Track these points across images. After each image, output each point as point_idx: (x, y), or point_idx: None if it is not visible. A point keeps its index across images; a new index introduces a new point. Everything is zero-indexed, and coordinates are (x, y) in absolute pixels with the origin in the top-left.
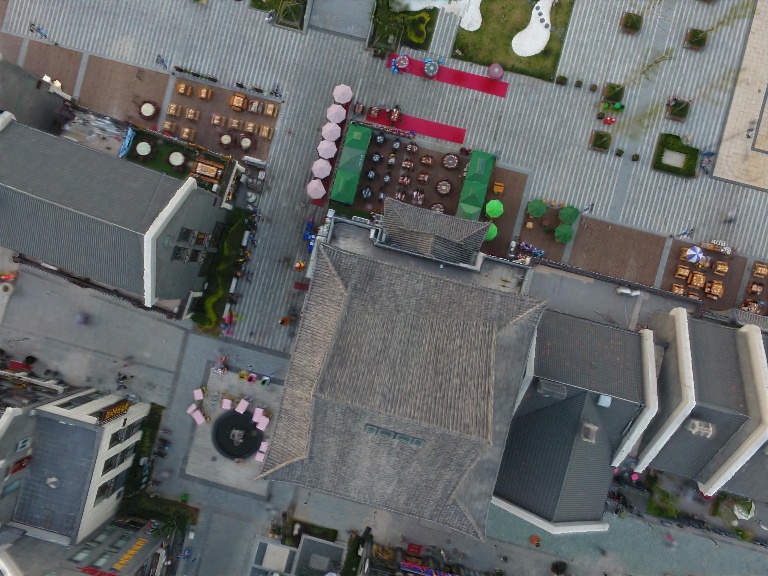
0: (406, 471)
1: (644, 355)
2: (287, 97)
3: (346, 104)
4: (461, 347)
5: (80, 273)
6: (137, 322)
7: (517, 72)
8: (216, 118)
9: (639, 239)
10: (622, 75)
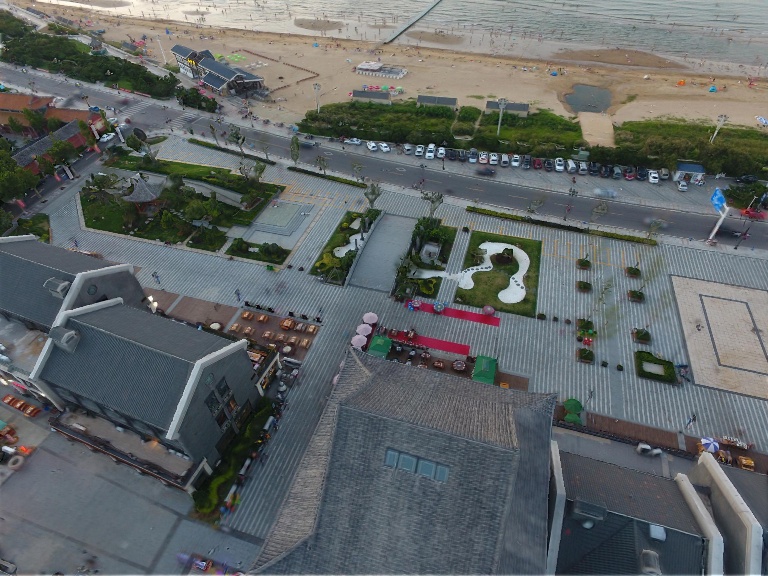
0: (430, 545)
1: (686, 496)
2: (326, 323)
3: (372, 326)
4: (479, 411)
5: (117, 408)
6: (131, 505)
7: (505, 312)
8: (267, 333)
9: (650, 434)
10: (588, 315)
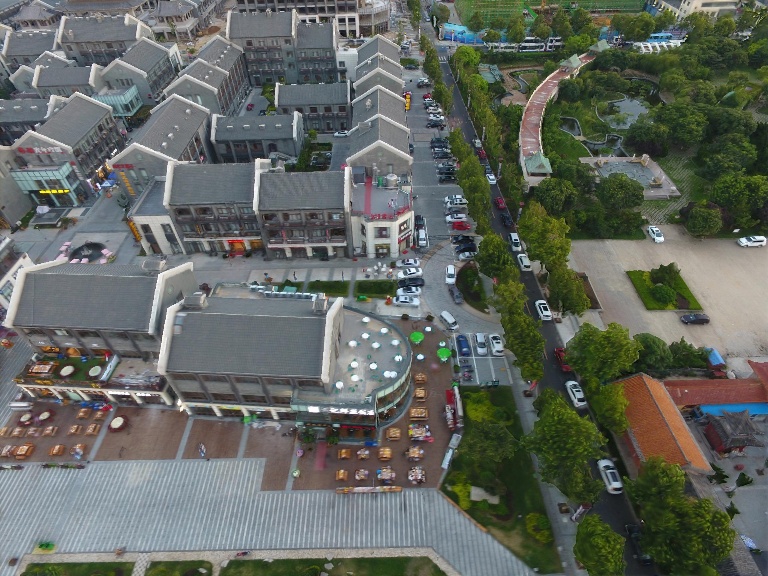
0: None
1: None
2: None
3: None
4: None
5: None
6: None
7: None
8: (49, 431)
9: None
10: None
